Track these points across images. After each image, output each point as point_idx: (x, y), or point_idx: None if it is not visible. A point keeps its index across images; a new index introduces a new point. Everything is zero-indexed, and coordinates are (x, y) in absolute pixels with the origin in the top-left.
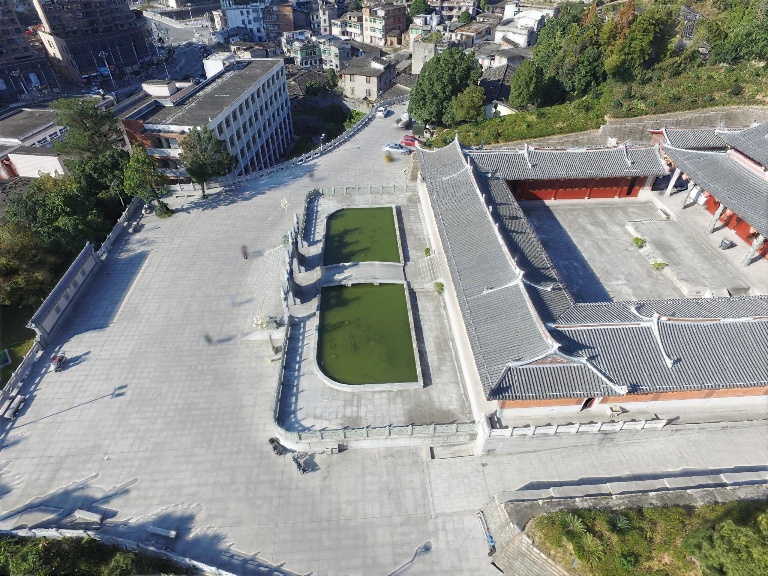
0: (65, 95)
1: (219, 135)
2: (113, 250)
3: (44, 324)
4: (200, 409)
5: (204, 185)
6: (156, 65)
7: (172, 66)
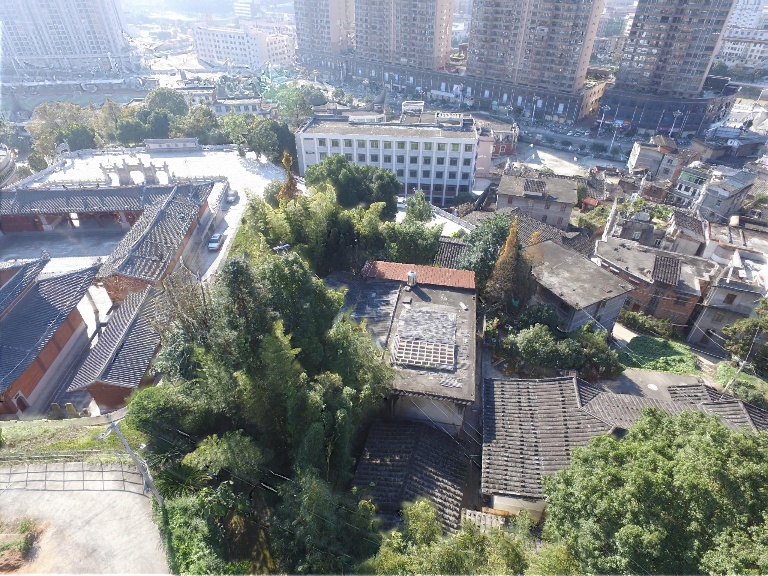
0: (512, 119)
1: (320, 145)
2: (210, 150)
3: (150, 145)
4: (85, 178)
5: None
6: (609, 129)
7: (688, 146)
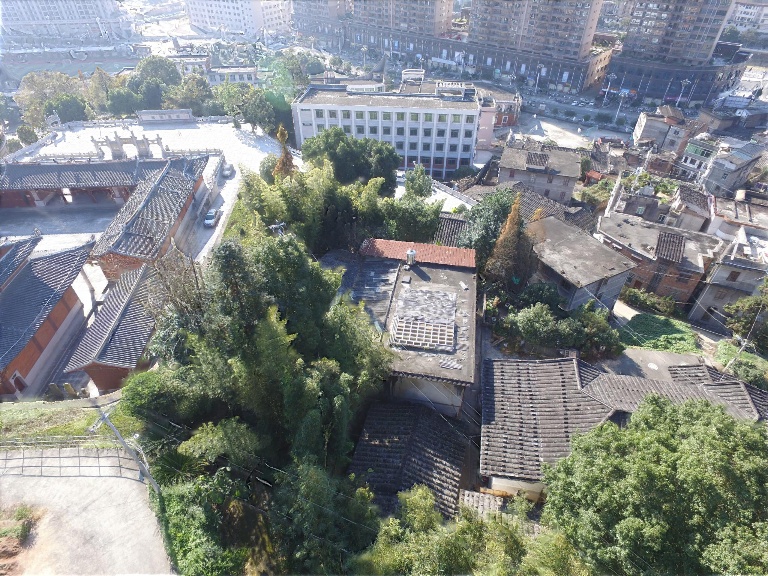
0: (515, 89)
1: (317, 117)
2: None
3: (143, 116)
4: None
5: (261, 128)
6: (614, 99)
7: (695, 116)
